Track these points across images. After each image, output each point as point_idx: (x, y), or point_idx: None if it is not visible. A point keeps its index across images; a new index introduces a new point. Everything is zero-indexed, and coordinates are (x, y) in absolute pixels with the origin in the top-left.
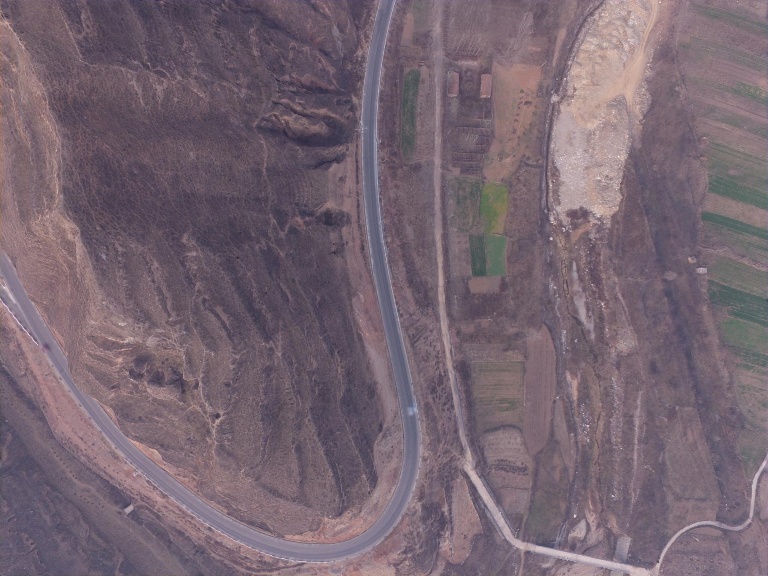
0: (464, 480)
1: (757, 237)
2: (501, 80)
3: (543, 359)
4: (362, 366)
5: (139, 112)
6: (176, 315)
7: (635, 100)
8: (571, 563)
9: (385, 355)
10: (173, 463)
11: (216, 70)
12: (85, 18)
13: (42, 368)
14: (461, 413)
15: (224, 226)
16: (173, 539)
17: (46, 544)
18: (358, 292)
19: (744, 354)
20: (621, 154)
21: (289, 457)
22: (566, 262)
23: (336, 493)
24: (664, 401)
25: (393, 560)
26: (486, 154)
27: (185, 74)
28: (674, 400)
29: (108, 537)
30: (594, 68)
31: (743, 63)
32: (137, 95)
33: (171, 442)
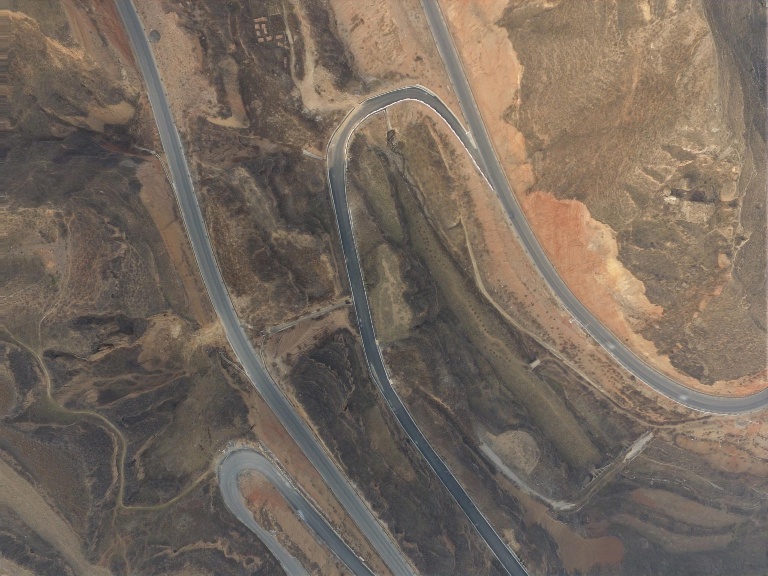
0: None
1: None
2: None
3: None
4: None
5: None
6: None
7: None
8: None
9: None
10: (654, 296)
11: None
12: None
13: (495, 213)
14: None
15: None
16: (568, 396)
17: (472, 390)
18: None
19: None
20: None
21: None
22: None
23: None
24: None
25: None
26: None
27: None
28: None
29: (513, 391)
30: None
31: None
32: None
33: (667, 272)
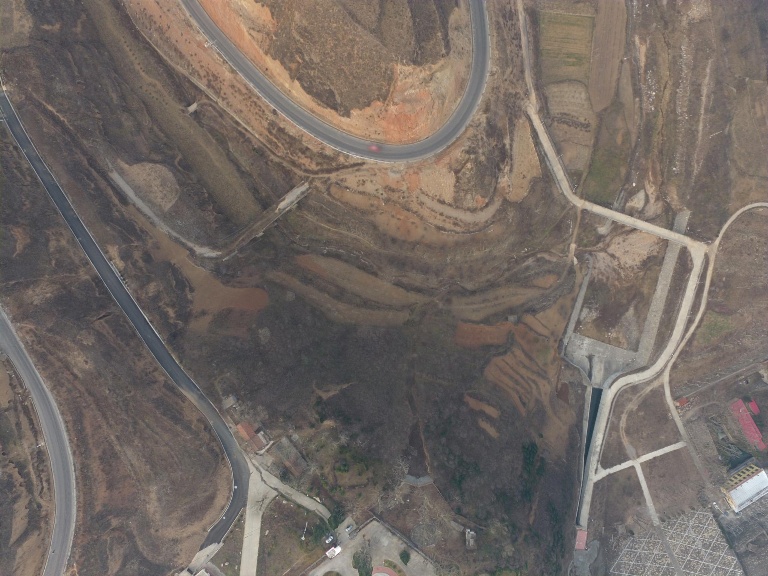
0: (527, 121)
1: None
2: None
3: (614, 16)
4: None
5: None
6: None
7: None
8: (627, 233)
9: None
10: None
11: None
12: None
13: None
14: (528, 55)
15: None
16: (232, 148)
17: (111, 120)
18: None
19: None
20: None
21: None
22: None
23: (412, 35)
24: (734, 71)
25: (455, 162)
26: None
27: None
28: (744, 71)
29: (169, 135)
30: None
31: None
32: None
33: None
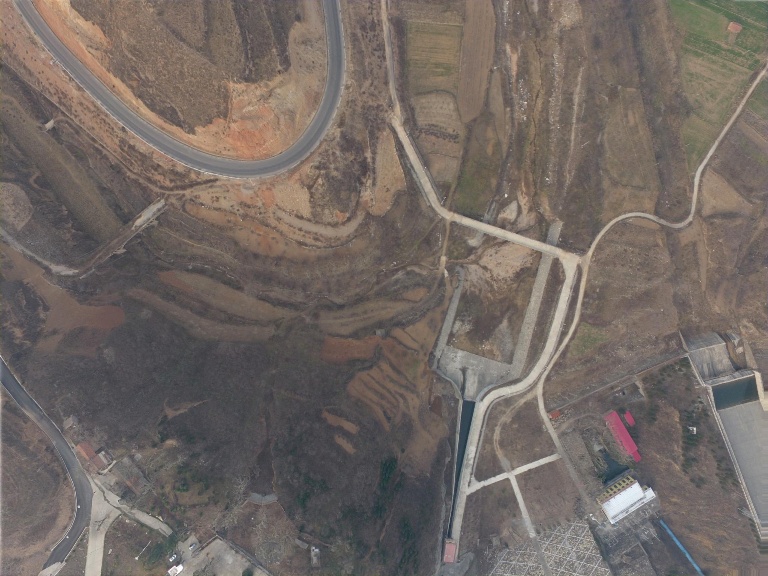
0: (391, 134)
1: None
2: None
3: (482, 24)
4: None
5: None
6: None
7: None
8: (499, 245)
9: None
10: (81, 9)
11: None
12: None
13: None
14: (393, 66)
15: None
16: (92, 165)
17: None
18: None
19: (694, 40)
20: None
21: None
22: None
23: (242, 52)
24: (606, 79)
25: (306, 178)
26: None
27: None
28: (617, 79)
29: (27, 153)
30: None
31: None
32: None
33: None
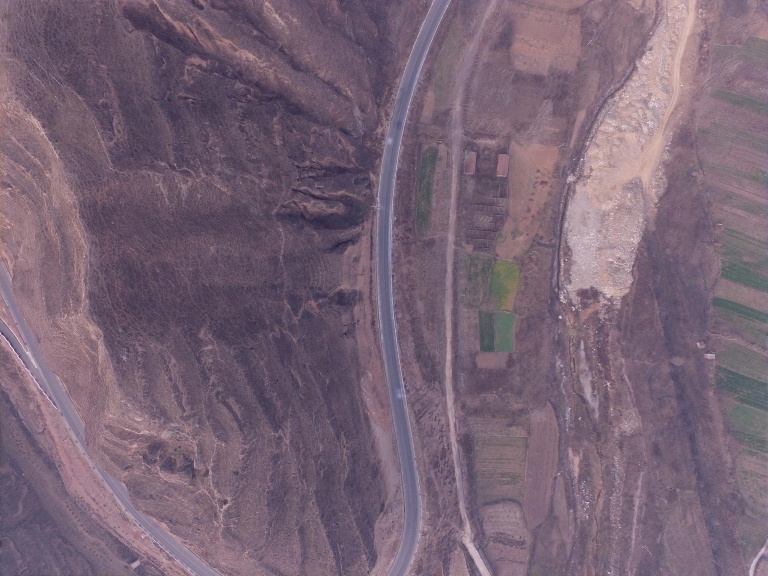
0: (462, 552)
1: (767, 324)
2: (518, 159)
3: (546, 436)
4: (367, 446)
5: (164, 211)
6: (190, 409)
7: (651, 183)
8: None
9: (390, 430)
10: (180, 536)
11: (239, 163)
12: (117, 123)
13: (59, 431)
14: (462, 486)
15: (240, 316)
16: None
17: None
18: (367, 370)
19: (748, 440)
20: (634, 237)
21: (292, 539)
22: (574, 341)
23: (336, 574)
24: (665, 483)
25: None
26: (499, 232)
27: (209, 171)
28: (675, 483)
29: None
30: (612, 150)
31: (763, 150)
32: (163, 195)
33: (179, 518)
